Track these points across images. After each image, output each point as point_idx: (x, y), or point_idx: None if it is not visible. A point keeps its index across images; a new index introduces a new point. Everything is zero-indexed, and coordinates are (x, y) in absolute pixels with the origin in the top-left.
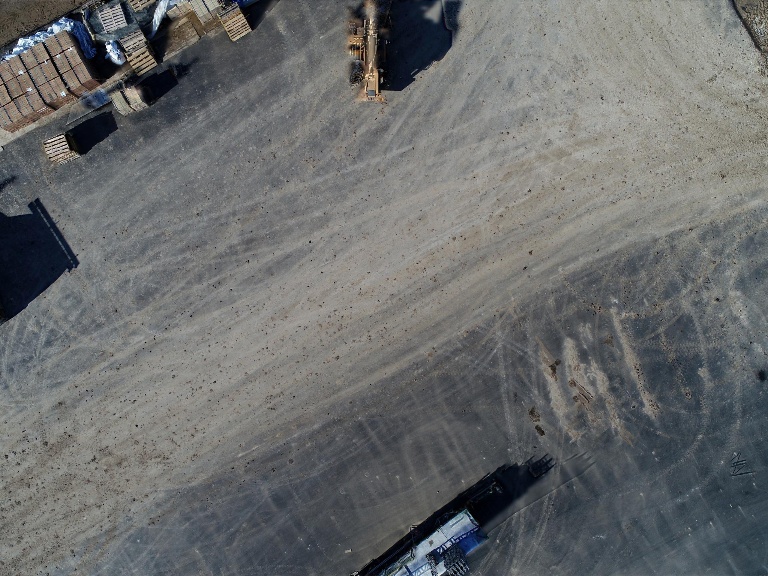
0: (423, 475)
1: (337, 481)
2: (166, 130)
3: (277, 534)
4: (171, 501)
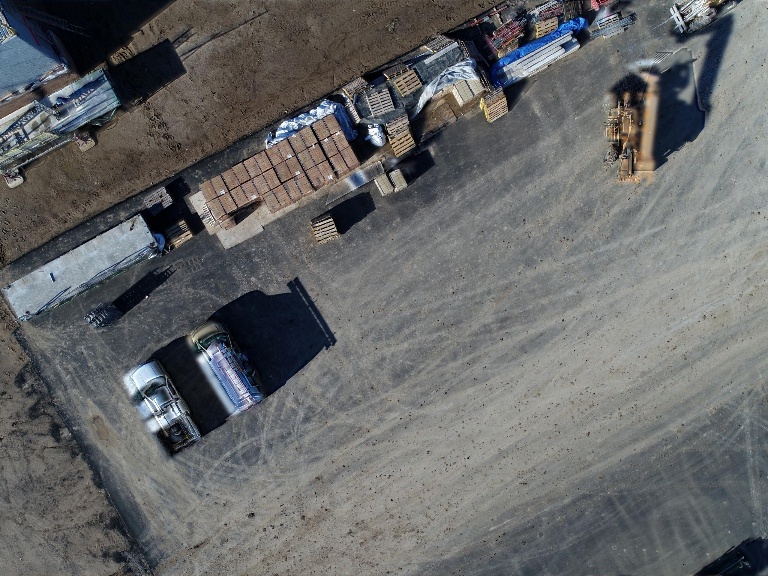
0: (669, 548)
1: (585, 554)
2: (423, 210)
3: None
4: (424, 573)
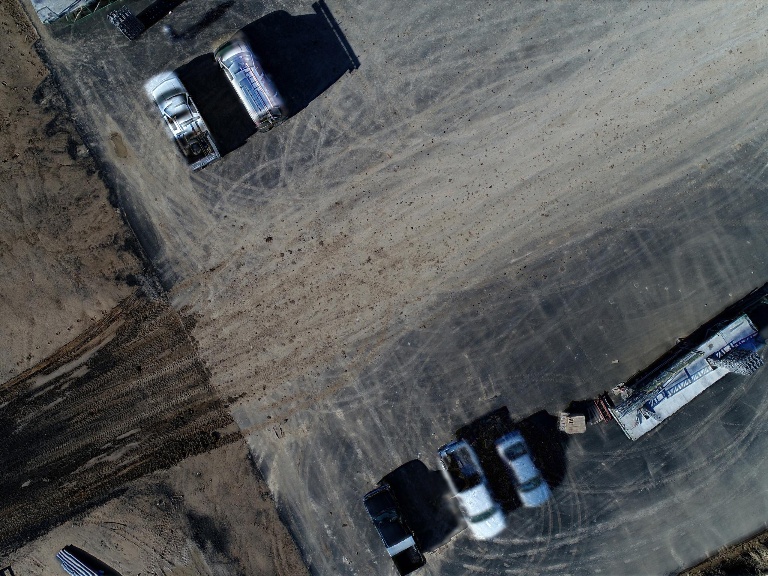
0: (692, 288)
1: (607, 291)
2: None
3: (546, 342)
4: (443, 305)
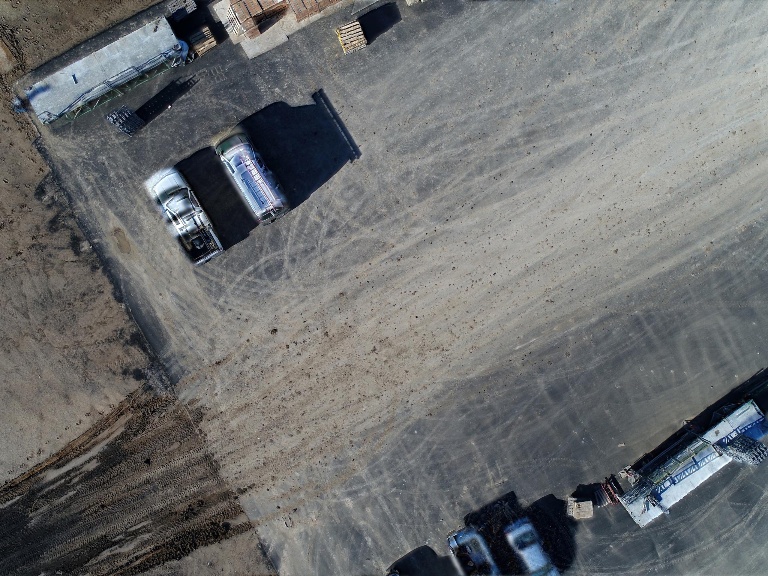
0: (697, 370)
1: (612, 375)
2: (449, 21)
3: (552, 427)
4: (449, 393)
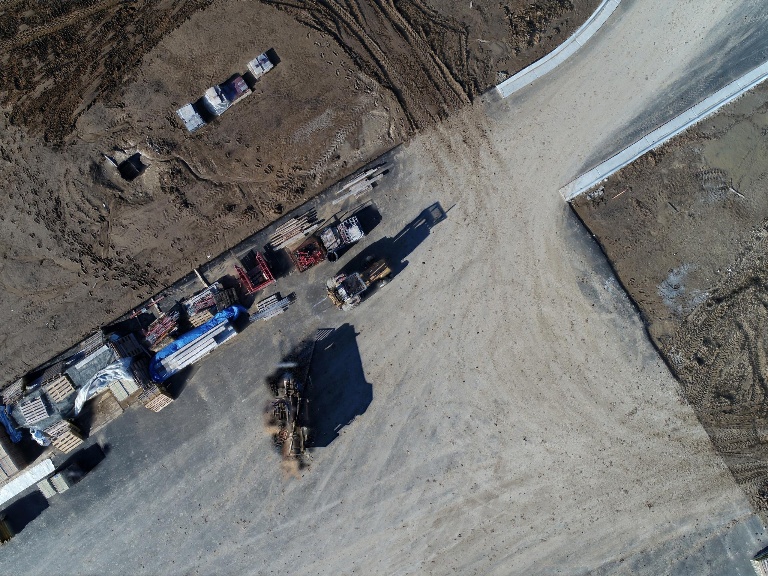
0: None
1: None
2: (97, 503)
3: None
4: None
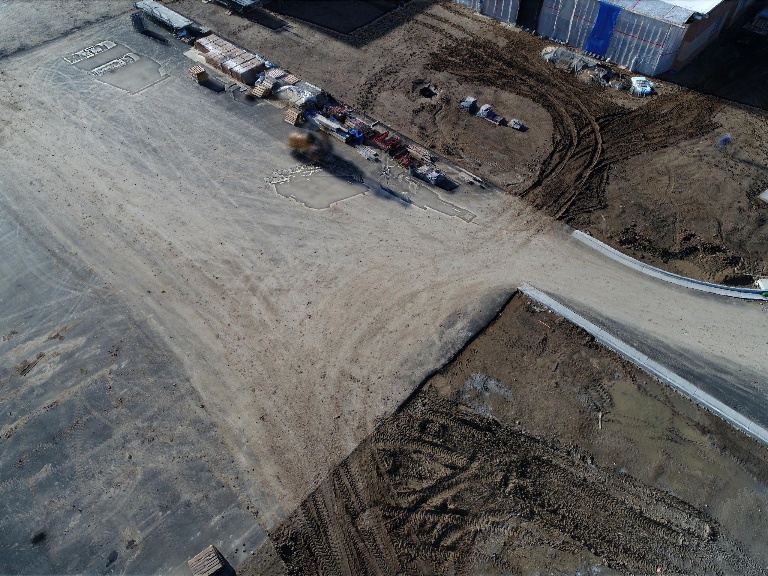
0: None
1: None
2: (222, 108)
3: None
4: None
